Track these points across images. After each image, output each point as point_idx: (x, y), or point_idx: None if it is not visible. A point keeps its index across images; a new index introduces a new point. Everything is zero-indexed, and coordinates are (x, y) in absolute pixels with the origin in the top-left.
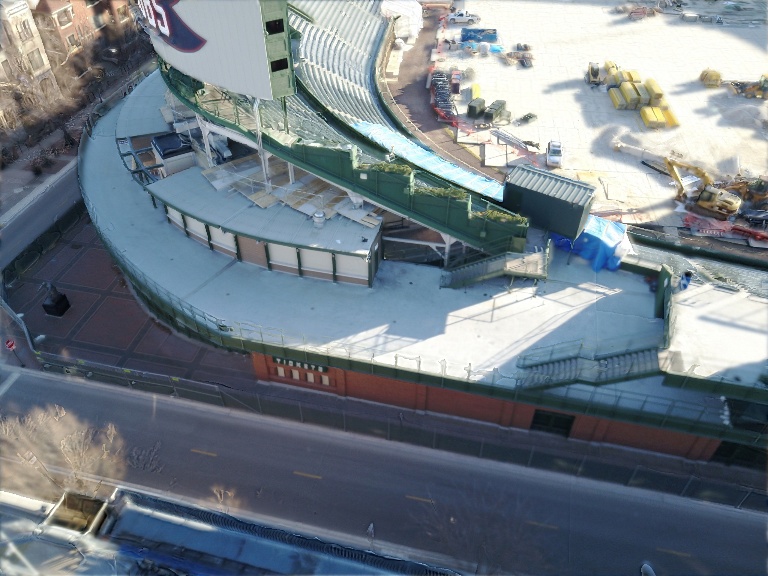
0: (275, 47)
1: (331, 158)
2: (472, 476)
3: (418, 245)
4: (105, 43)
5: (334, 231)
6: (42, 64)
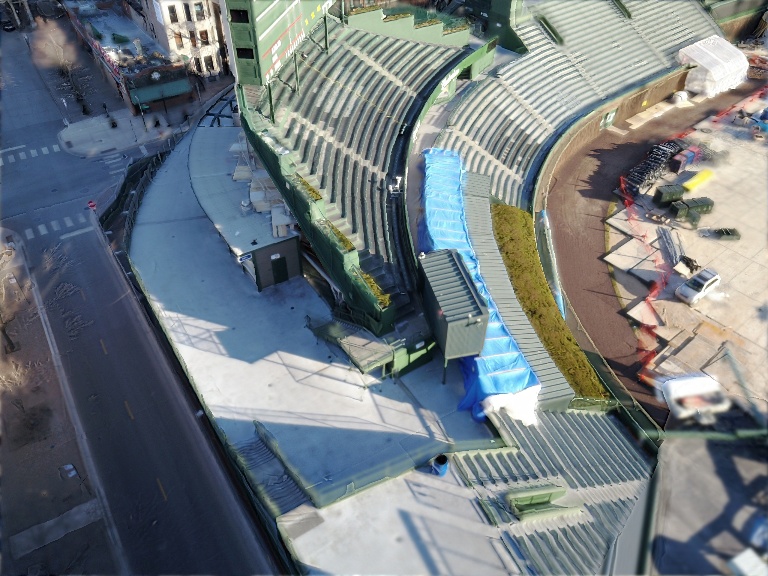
0: (240, 35)
1: (271, 157)
2: (212, 507)
3: (321, 277)
4: None
5: (248, 224)
6: None
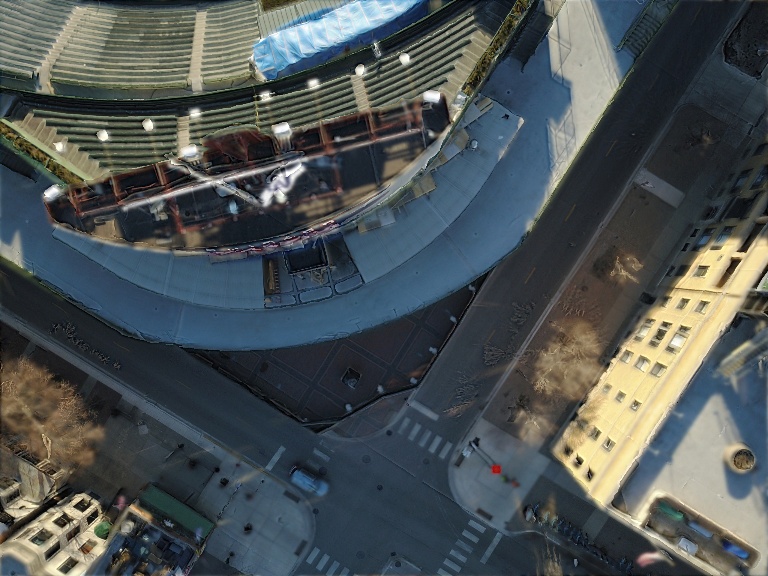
0: None
1: None
2: (609, 110)
3: None
4: None
5: (485, 137)
6: None
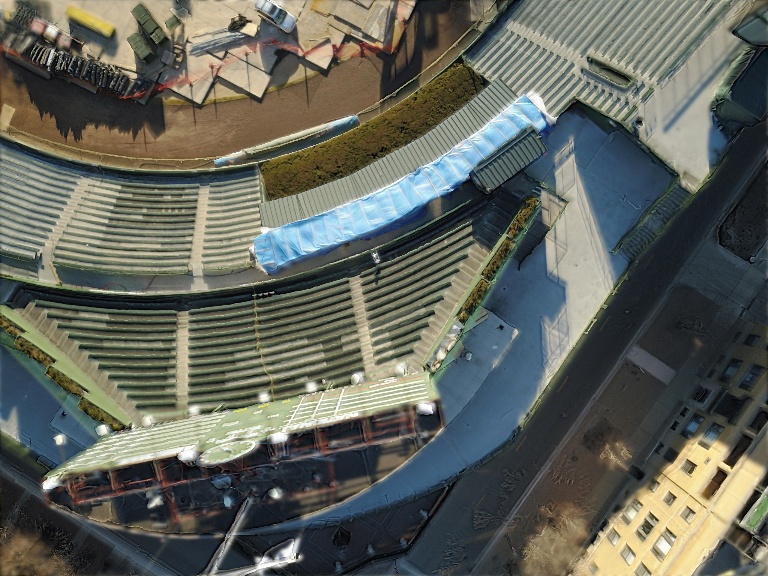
0: None
1: None
2: None
3: None
4: None
5: (480, 346)
6: None
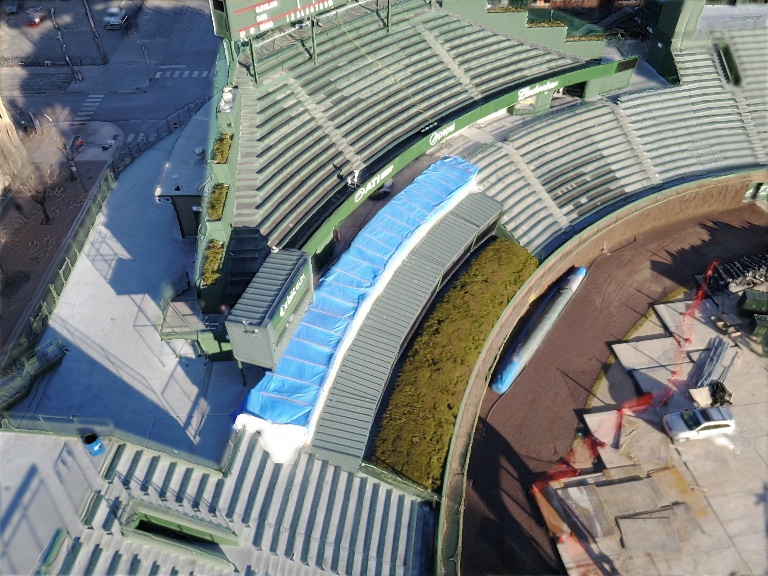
0: None
1: None
2: None
3: None
4: (596, 15)
5: (192, 171)
6: (499, 2)
